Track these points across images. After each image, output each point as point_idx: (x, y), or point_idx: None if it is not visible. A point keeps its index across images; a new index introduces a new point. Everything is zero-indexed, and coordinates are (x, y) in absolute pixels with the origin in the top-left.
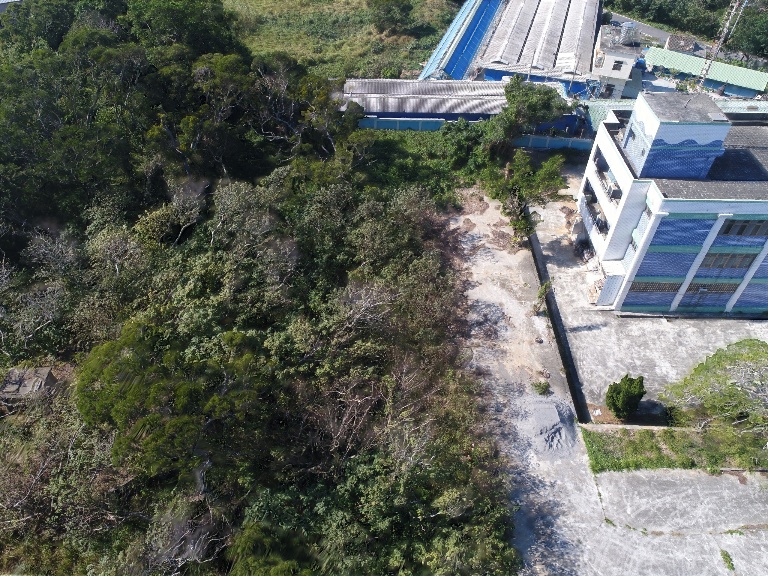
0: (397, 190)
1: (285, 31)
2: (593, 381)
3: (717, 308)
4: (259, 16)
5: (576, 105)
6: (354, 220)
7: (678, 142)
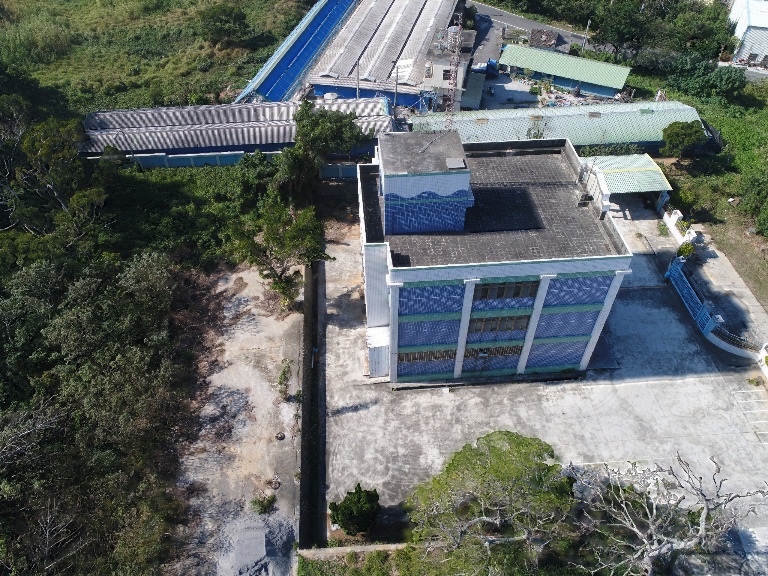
0: (146, 253)
1: (103, 51)
2: (342, 482)
3: (507, 371)
4: (79, 35)
5: (373, 132)
6: (59, 306)
7: (415, 195)
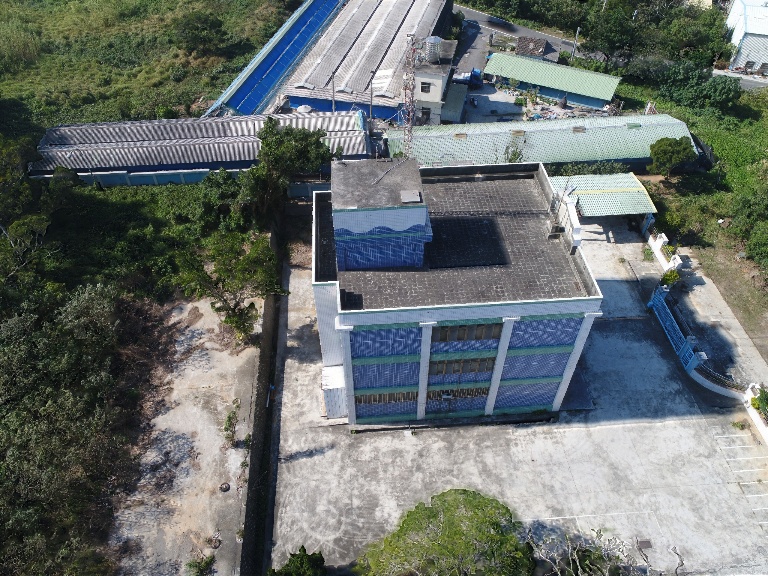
0: None
1: (73, 60)
2: (290, 537)
3: (475, 412)
4: (51, 42)
5: (340, 151)
6: None
7: (367, 230)
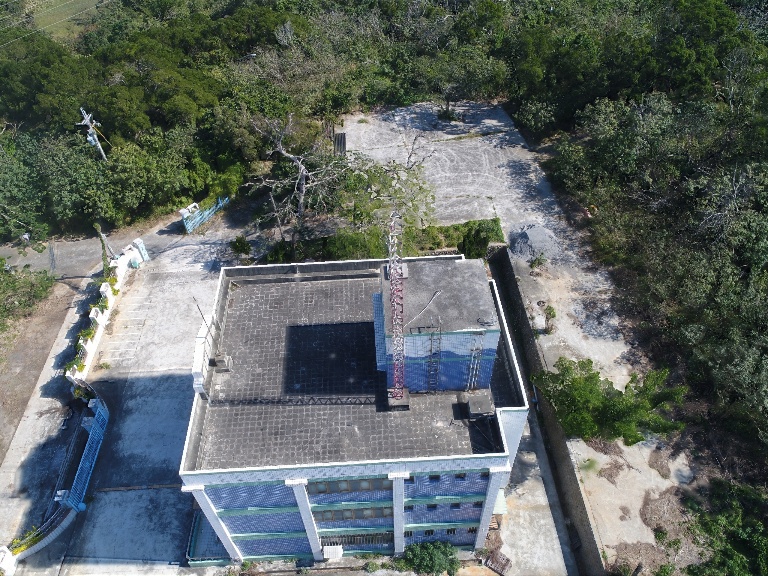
0: None
1: None
2: None
3: None
4: None
5: None
6: None
7: None
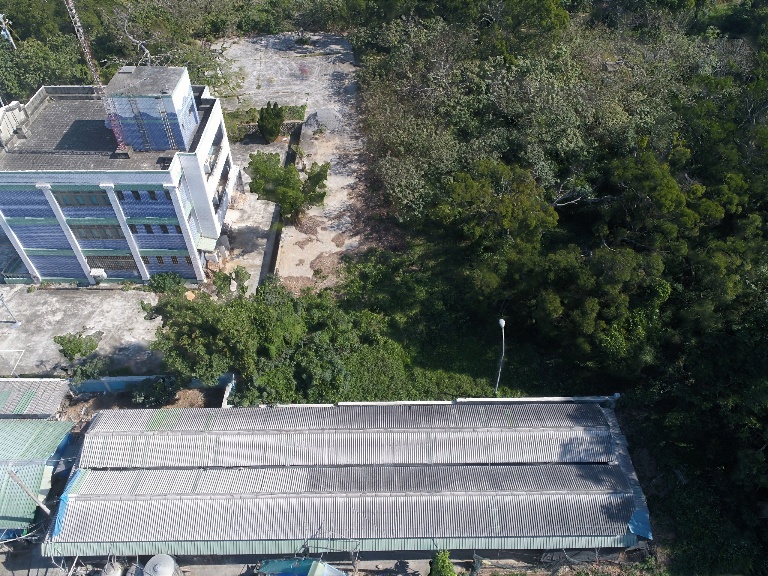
0: None
1: None
2: None
3: None
4: None
5: None
6: None
7: None
